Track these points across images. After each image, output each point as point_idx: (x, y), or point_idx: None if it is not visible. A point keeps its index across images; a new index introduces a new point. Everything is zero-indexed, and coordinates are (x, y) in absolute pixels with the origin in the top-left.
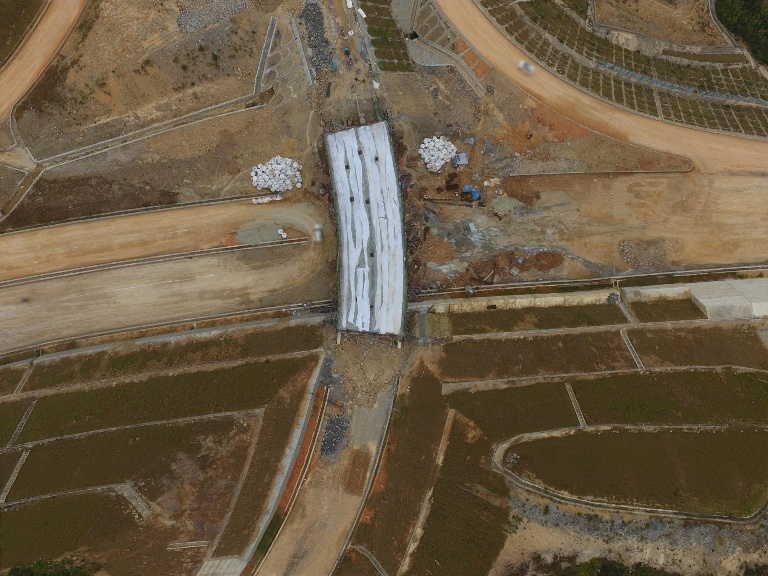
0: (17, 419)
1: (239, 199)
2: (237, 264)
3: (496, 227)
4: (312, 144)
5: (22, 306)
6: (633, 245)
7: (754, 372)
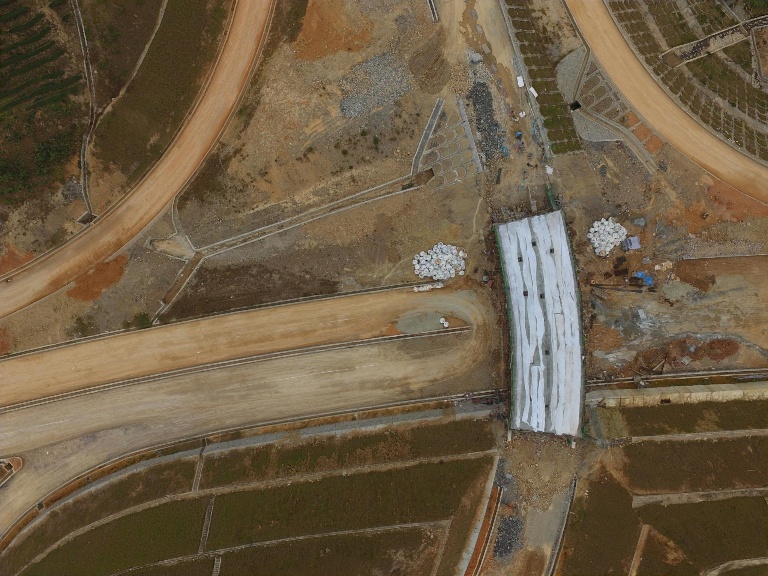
0: (200, 520)
1: (400, 287)
2: (397, 353)
3: (667, 313)
4: (478, 231)
5: (187, 396)
6: None
7: None
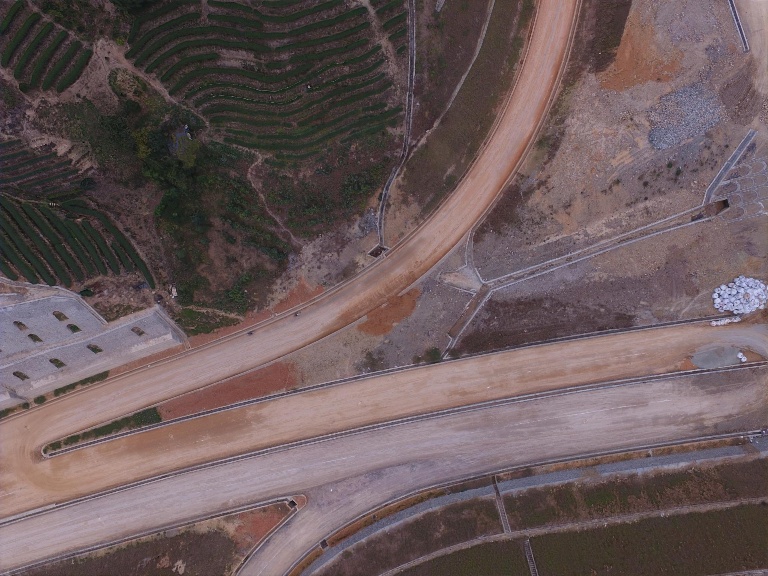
0: (525, 564)
1: (697, 321)
2: (692, 389)
3: None
4: None
5: (475, 432)
6: None
7: None
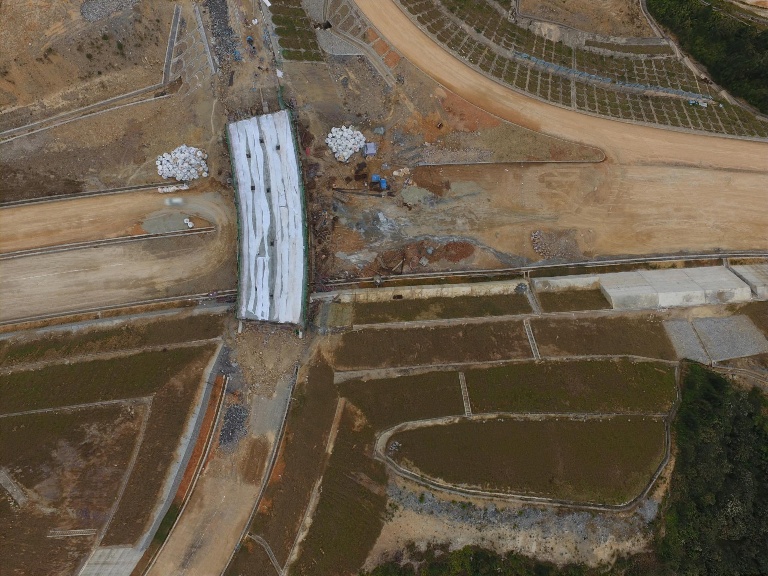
0: None
1: (145, 188)
2: (143, 253)
3: (406, 217)
4: (217, 133)
5: None
6: (544, 235)
7: (652, 362)
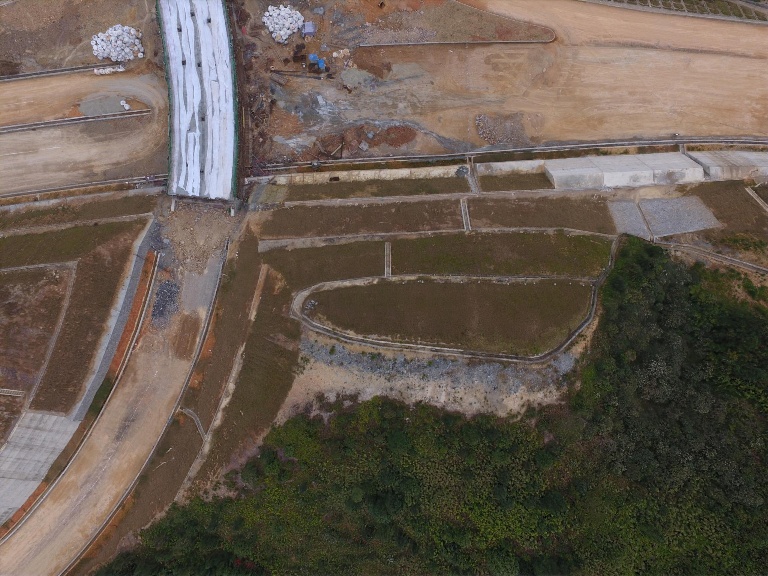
0: None
1: (81, 70)
2: (80, 136)
3: (345, 100)
4: (151, 11)
5: None
6: (489, 119)
7: (588, 235)
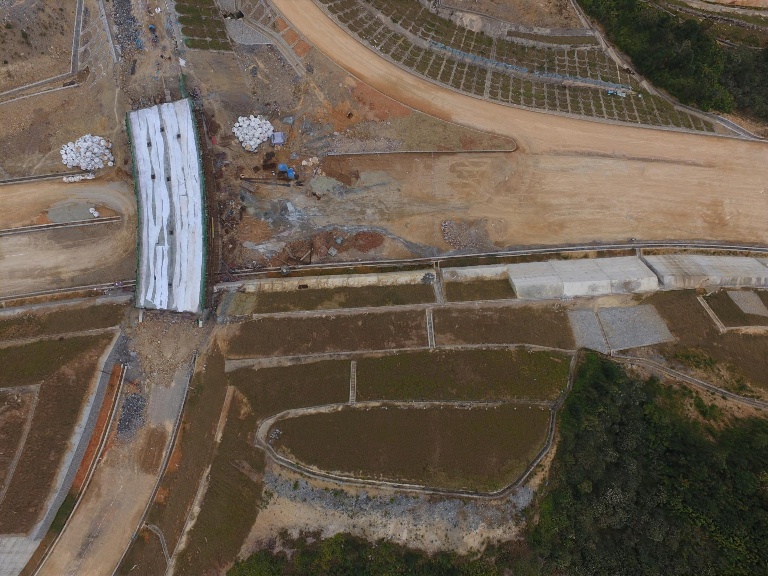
0: None
1: (50, 177)
2: (48, 243)
3: (314, 207)
4: (121, 122)
5: None
6: (454, 225)
7: (548, 351)
